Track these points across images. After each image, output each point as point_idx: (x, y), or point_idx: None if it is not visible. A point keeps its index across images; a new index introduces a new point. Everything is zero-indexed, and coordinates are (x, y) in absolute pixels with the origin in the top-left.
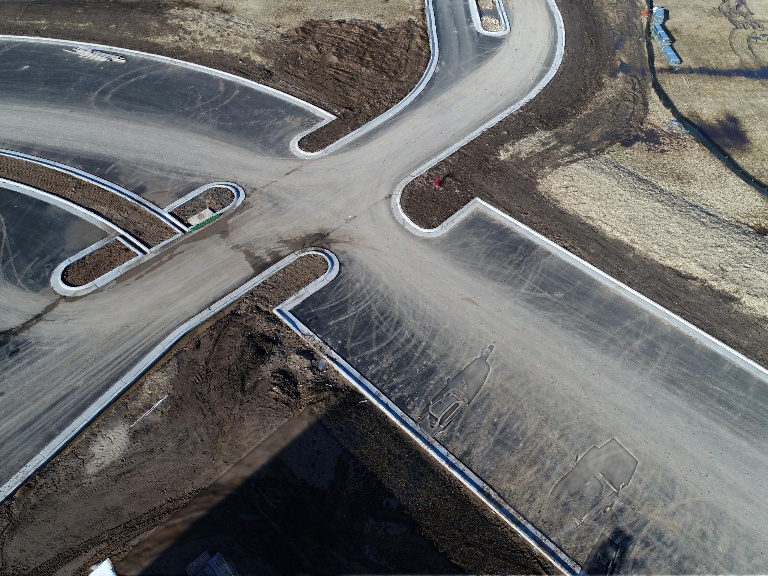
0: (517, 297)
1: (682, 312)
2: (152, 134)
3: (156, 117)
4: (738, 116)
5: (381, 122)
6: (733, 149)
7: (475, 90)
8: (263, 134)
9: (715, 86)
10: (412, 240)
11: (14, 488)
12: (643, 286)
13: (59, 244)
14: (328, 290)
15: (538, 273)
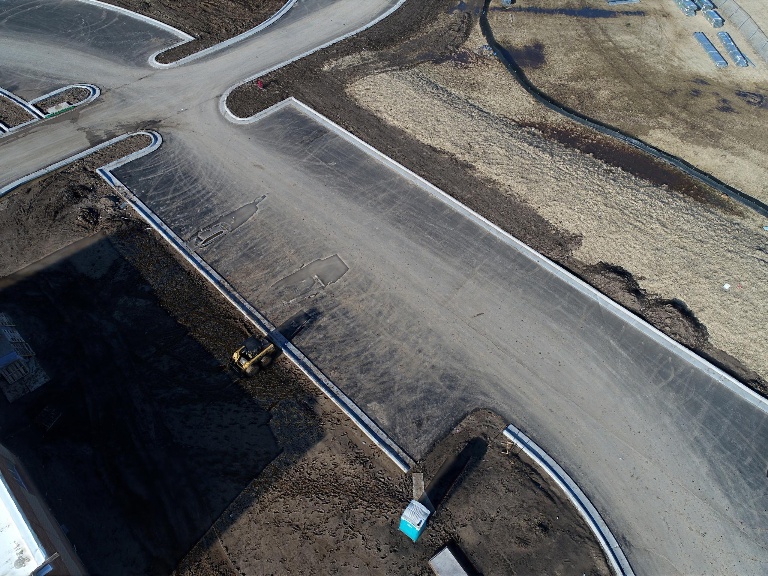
0: (298, 164)
1: (426, 175)
2: (34, 49)
3: (41, 37)
4: (544, 43)
5: (232, 43)
6: (528, 67)
7: (322, 20)
8: (129, 50)
9: (535, 21)
10: (227, 126)
11: None
12: (402, 158)
13: None
14: (146, 158)
15: (322, 149)
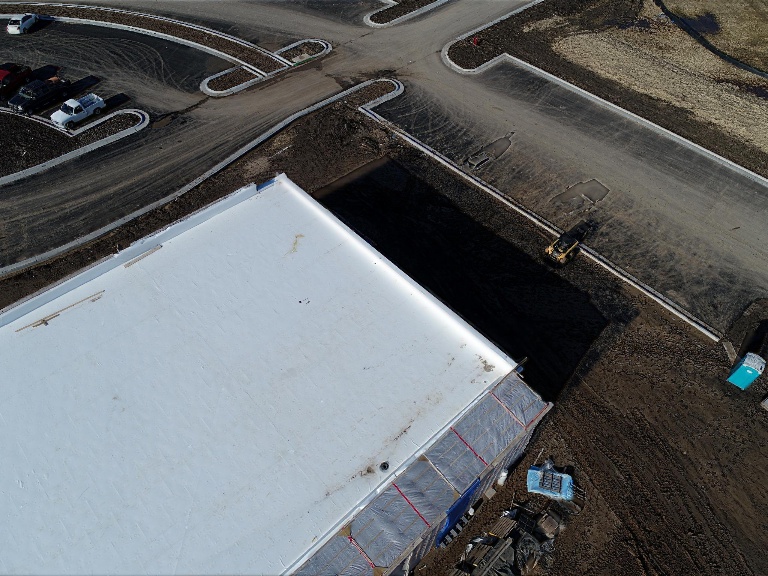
0: (532, 108)
1: (651, 118)
2: (259, 9)
3: None
4: (715, 14)
5: (433, 7)
6: (707, 33)
7: None
8: (343, 12)
9: None
10: (457, 76)
11: (199, 183)
12: (625, 104)
13: (202, 69)
14: (397, 100)
15: (549, 96)
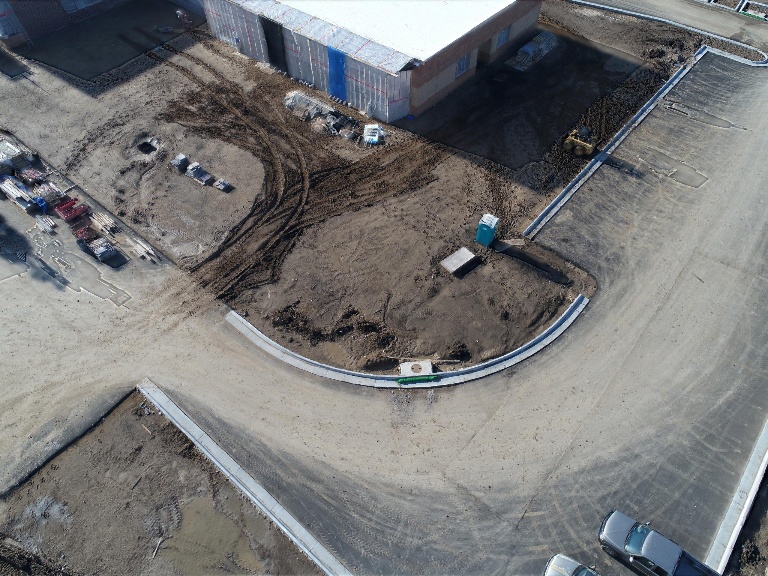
0: None
1: None
2: None
3: None
4: None
5: None
6: None
7: None
8: None
9: None
10: None
11: None
12: None
13: None
14: (738, 64)
15: None
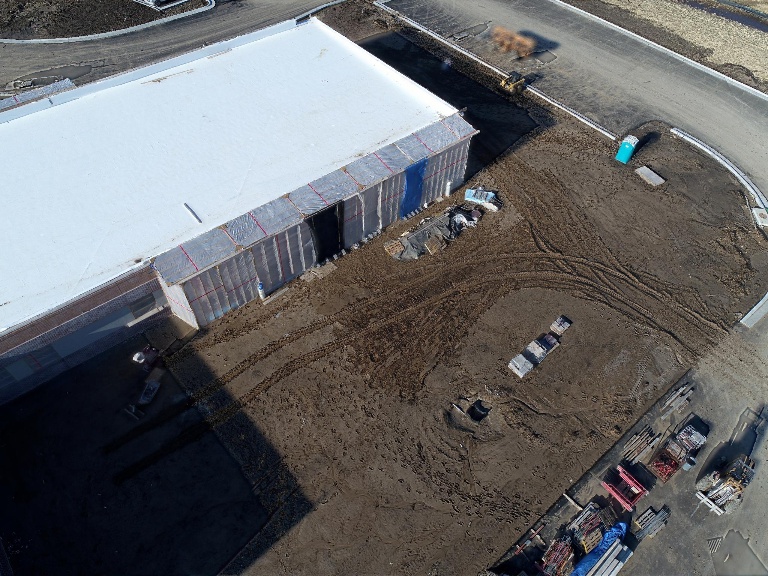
0: (508, 7)
1: (600, 15)
2: None
3: None
4: None
5: None
6: None
7: None
8: None
9: None
10: None
11: None
12: (581, 6)
13: None
14: None
15: None
